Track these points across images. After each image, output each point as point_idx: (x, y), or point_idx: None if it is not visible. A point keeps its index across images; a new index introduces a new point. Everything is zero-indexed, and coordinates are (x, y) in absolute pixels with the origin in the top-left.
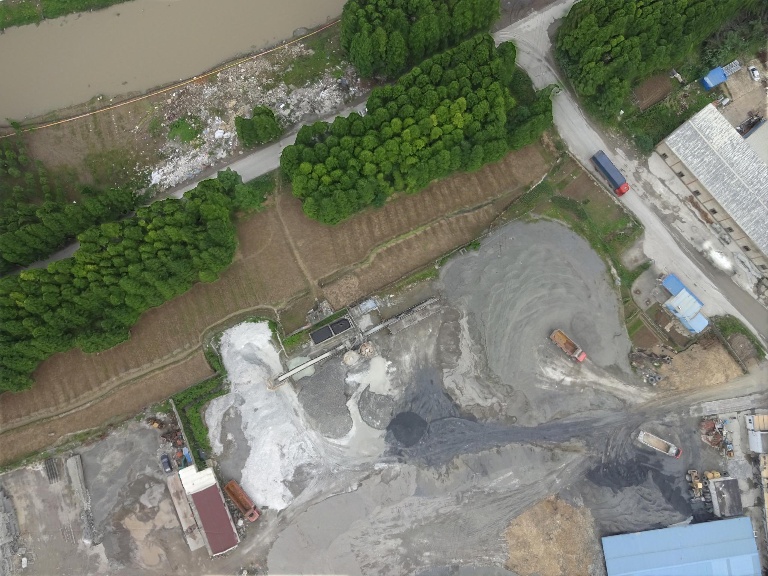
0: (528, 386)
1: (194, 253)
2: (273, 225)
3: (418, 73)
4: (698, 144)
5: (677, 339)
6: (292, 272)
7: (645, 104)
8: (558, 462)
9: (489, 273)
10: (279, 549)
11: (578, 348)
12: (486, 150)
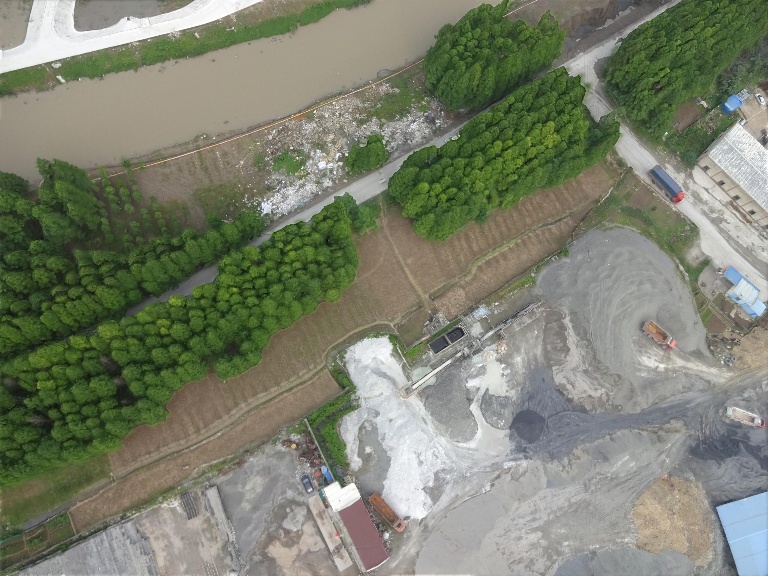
0: (632, 374)
1: (328, 271)
2: (383, 245)
3: (513, 101)
4: (734, 156)
5: (741, 323)
6: (404, 288)
7: (681, 126)
8: (664, 443)
9: (583, 275)
10: (427, 558)
11: (668, 336)
12: (571, 167)
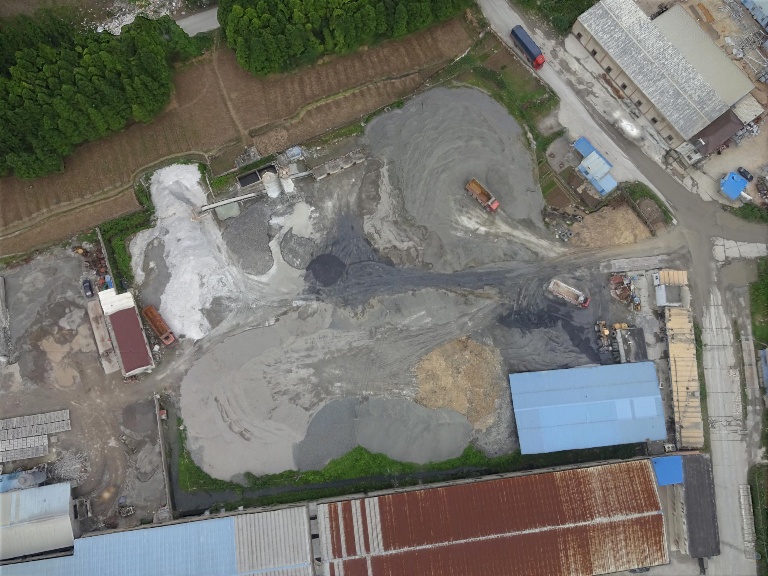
0: (443, 230)
1: (127, 82)
2: (209, 77)
3: None
4: (608, 22)
5: (589, 200)
6: (224, 121)
7: None
8: (471, 306)
9: (410, 126)
10: (193, 375)
11: (491, 197)
12: (409, 11)
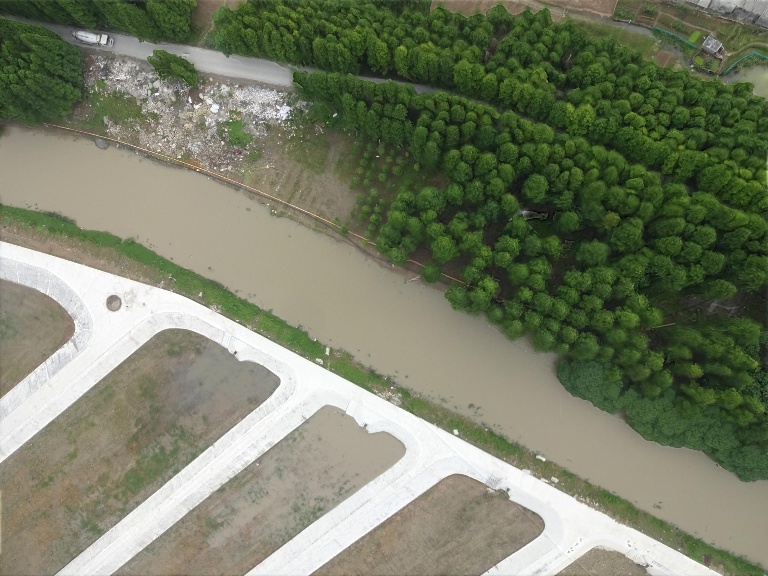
0: None
1: None
2: (234, 4)
3: None
4: None
5: None
6: None
7: None
8: None
9: None
10: None
11: None
12: None
